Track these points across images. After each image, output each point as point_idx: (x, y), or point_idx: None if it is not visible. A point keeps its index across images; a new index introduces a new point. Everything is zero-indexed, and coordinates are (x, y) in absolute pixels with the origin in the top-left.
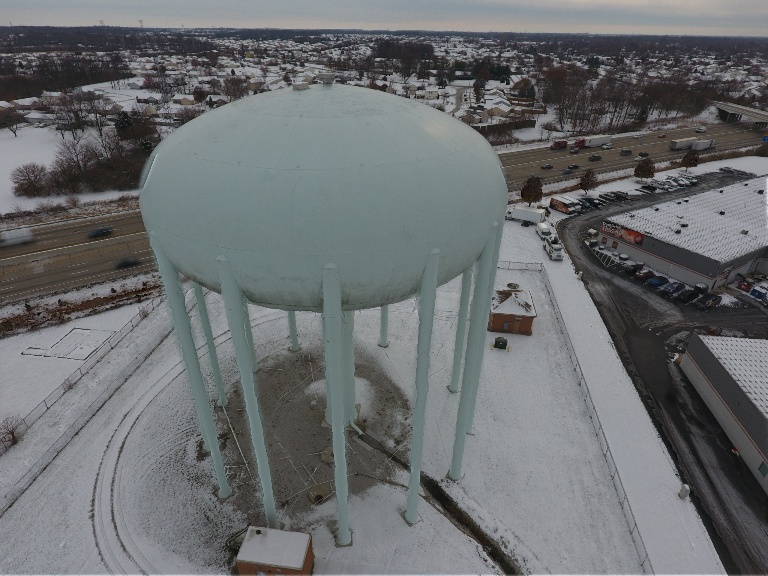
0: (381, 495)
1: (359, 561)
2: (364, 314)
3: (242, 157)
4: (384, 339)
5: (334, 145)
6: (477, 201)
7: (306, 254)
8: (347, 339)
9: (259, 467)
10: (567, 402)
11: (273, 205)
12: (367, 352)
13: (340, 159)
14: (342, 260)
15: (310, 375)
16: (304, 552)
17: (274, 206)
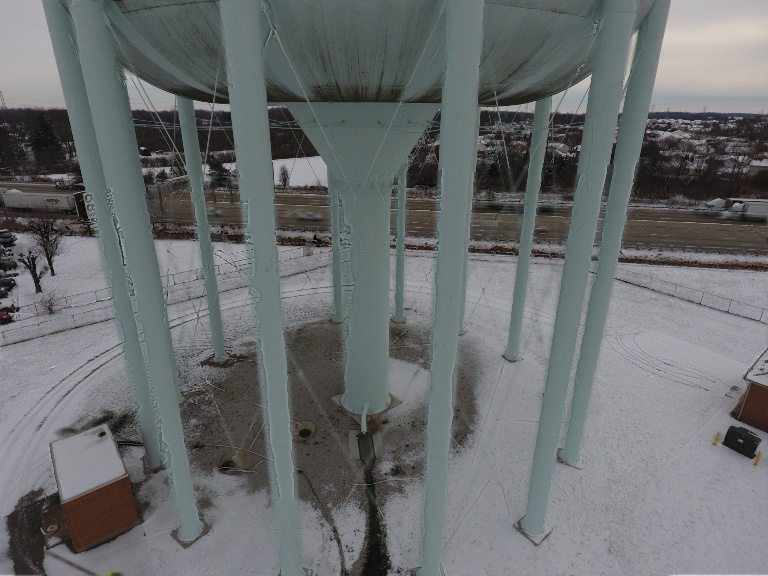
0: None
1: (164, 575)
2: None
3: None
4: (512, 348)
5: None
6: None
7: None
8: (370, 264)
9: None
10: None
11: None
12: (478, 355)
13: None
14: None
15: None
16: (92, 486)
17: None
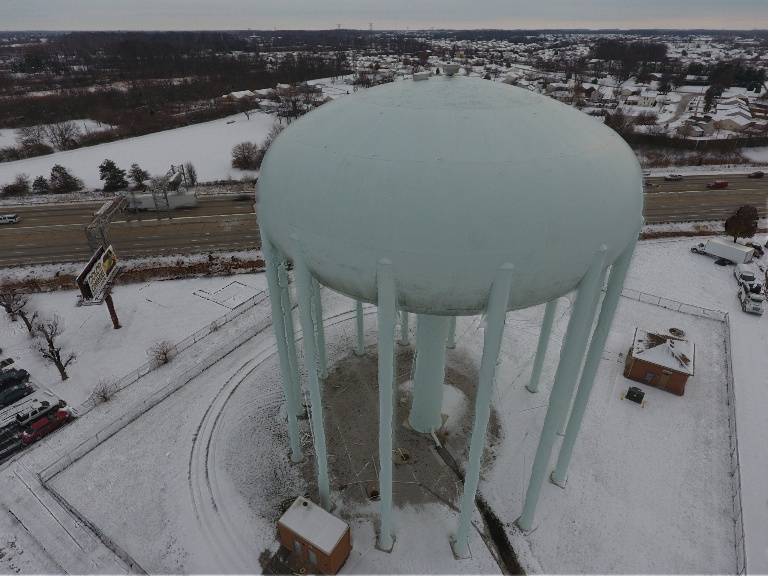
0: (437, 515)
1: (392, 571)
2: None
3: (330, 142)
4: None
5: (418, 137)
6: (577, 217)
7: (362, 245)
8: (439, 344)
9: (316, 443)
10: (705, 491)
11: (341, 191)
12: (474, 364)
13: (418, 152)
14: (397, 257)
15: (409, 372)
16: (337, 539)
17: (341, 192)
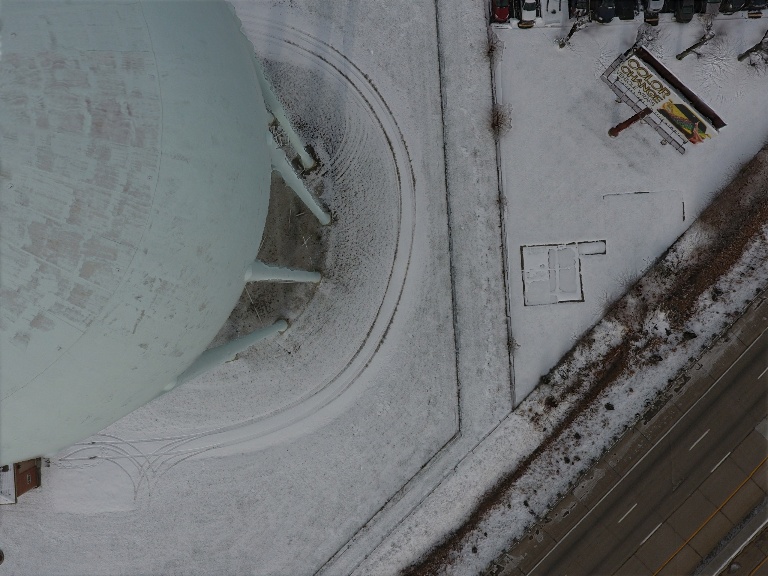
0: None
1: None
2: (212, 421)
3: None
4: None
5: None
6: None
7: None
8: None
9: None
10: None
11: None
12: None
13: None
14: None
15: None
16: None
17: None
